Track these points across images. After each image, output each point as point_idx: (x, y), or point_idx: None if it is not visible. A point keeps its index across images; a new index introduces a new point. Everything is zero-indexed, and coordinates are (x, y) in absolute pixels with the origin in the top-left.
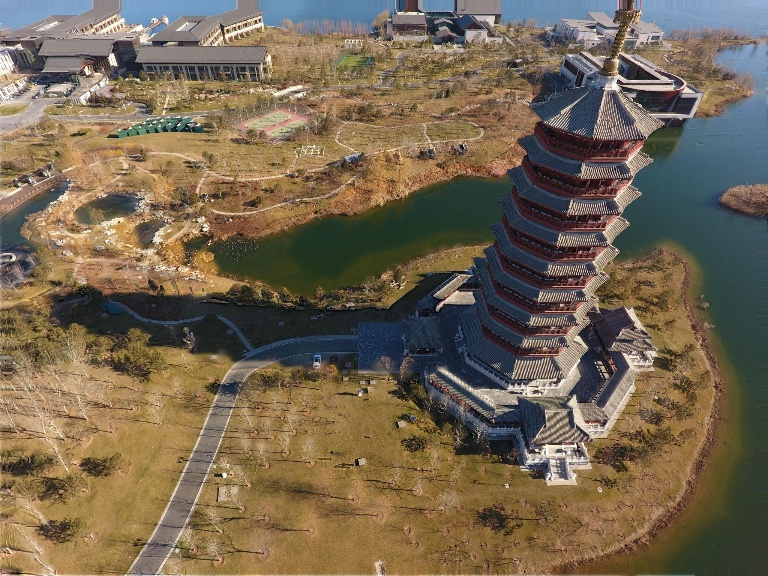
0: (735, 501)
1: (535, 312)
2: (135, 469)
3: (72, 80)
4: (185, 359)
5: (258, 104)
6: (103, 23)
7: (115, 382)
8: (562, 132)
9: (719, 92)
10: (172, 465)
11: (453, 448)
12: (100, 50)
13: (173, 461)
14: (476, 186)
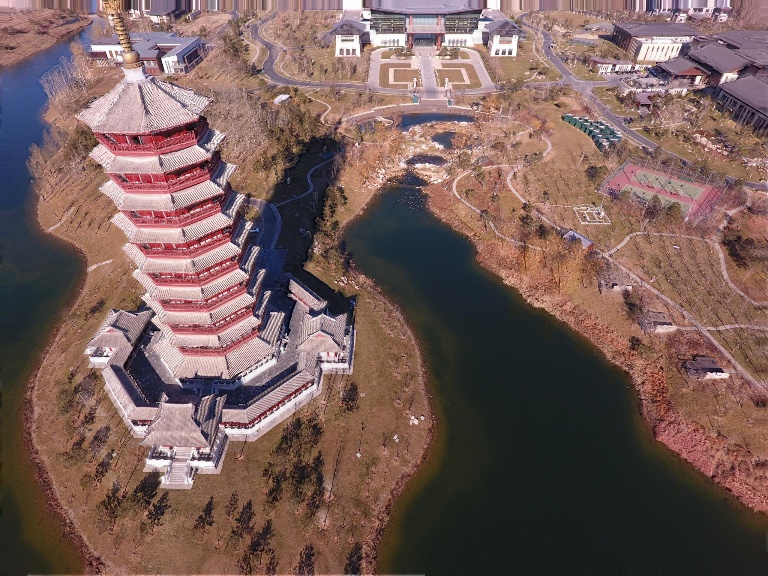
0: None
1: None
2: None
3: (668, 81)
4: (263, 176)
5: None
6: None
7: None
8: None
9: None
10: None
11: None
12: None
13: None
14: (622, 407)
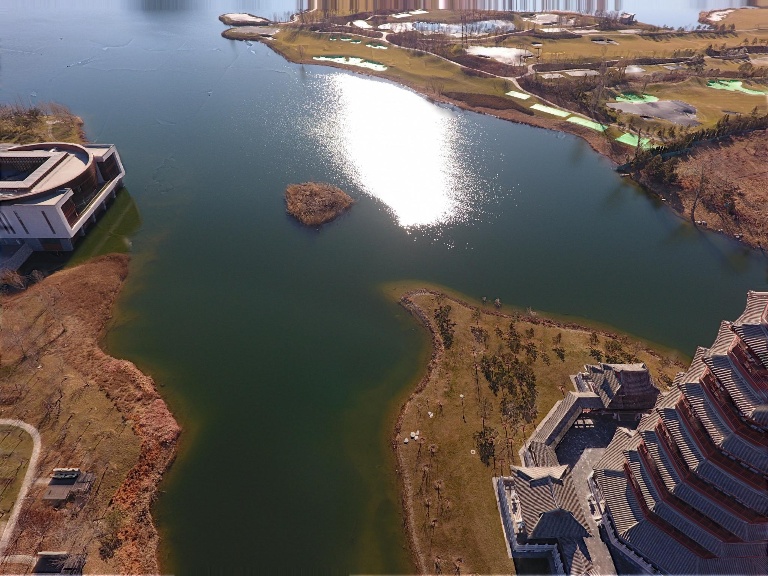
0: None
1: None
2: None
3: None
4: None
5: None
6: None
7: None
8: None
9: (63, 133)
10: None
11: None
12: None
13: None
14: (182, 481)
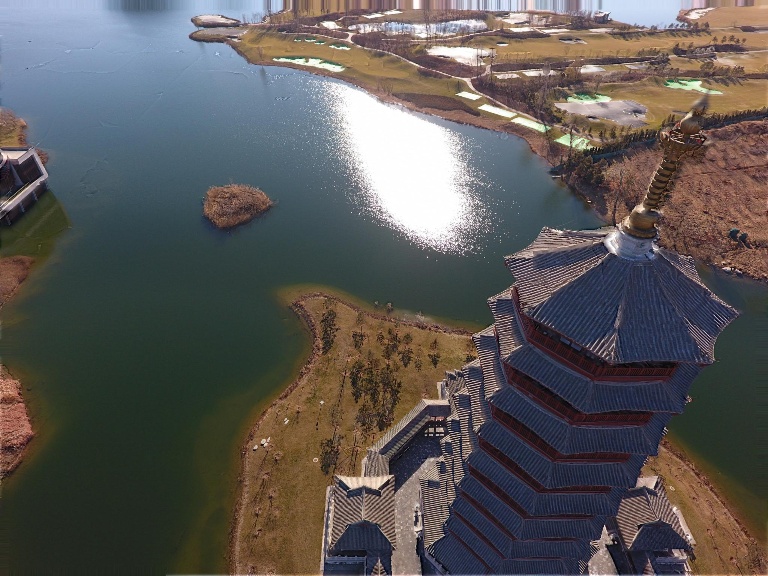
0: None
1: None
2: None
3: None
4: None
5: None
6: None
7: None
8: None
9: (2, 136)
10: None
11: None
12: None
13: None
14: (25, 486)
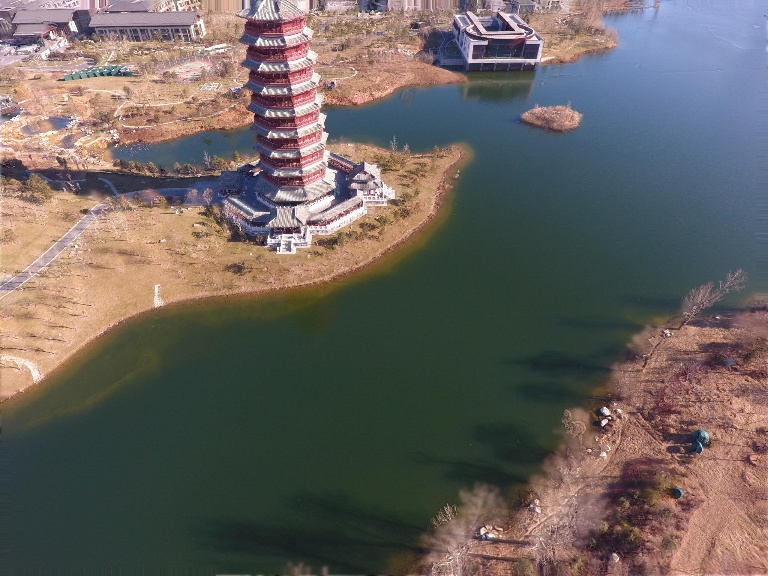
0: (401, 268)
1: (273, 148)
2: (23, 243)
3: (38, 42)
4: (67, 193)
5: (180, 56)
6: (76, 0)
7: (20, 205)
8: (249, 20)
9: (583, 44)
10: (46, 243)
11: (227, 239)
12: (62, 18)
13: (48, 241)
14: (339, 112)
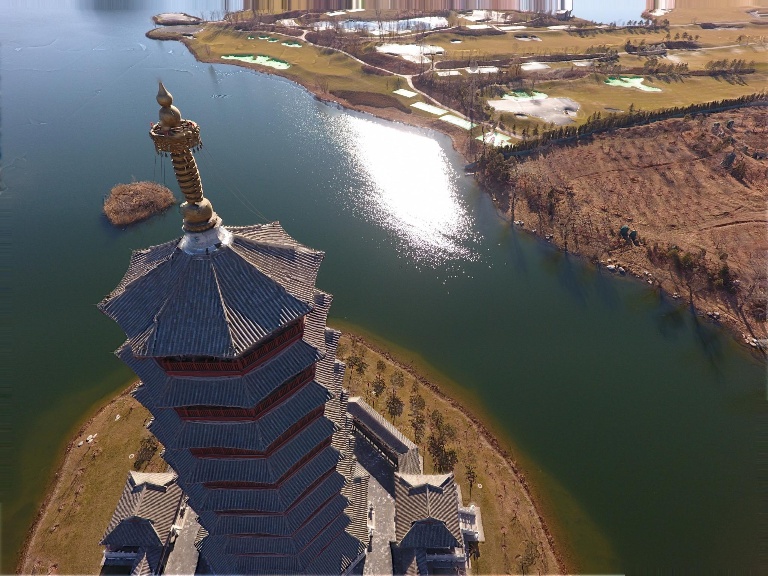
0: (462, 380)
1: None
2: None
3: None
4: None
5: None
6: None
7: None
8: None
9: None
10: None
11: None
12: None
13: None
14: None
